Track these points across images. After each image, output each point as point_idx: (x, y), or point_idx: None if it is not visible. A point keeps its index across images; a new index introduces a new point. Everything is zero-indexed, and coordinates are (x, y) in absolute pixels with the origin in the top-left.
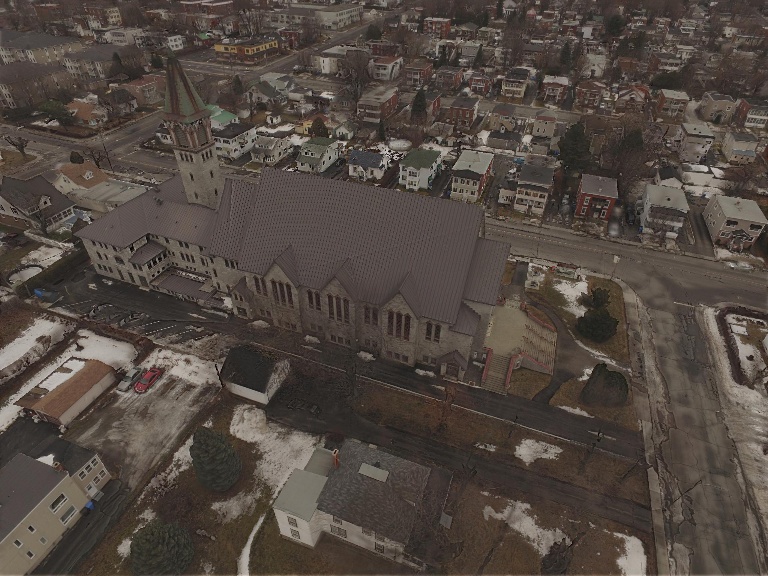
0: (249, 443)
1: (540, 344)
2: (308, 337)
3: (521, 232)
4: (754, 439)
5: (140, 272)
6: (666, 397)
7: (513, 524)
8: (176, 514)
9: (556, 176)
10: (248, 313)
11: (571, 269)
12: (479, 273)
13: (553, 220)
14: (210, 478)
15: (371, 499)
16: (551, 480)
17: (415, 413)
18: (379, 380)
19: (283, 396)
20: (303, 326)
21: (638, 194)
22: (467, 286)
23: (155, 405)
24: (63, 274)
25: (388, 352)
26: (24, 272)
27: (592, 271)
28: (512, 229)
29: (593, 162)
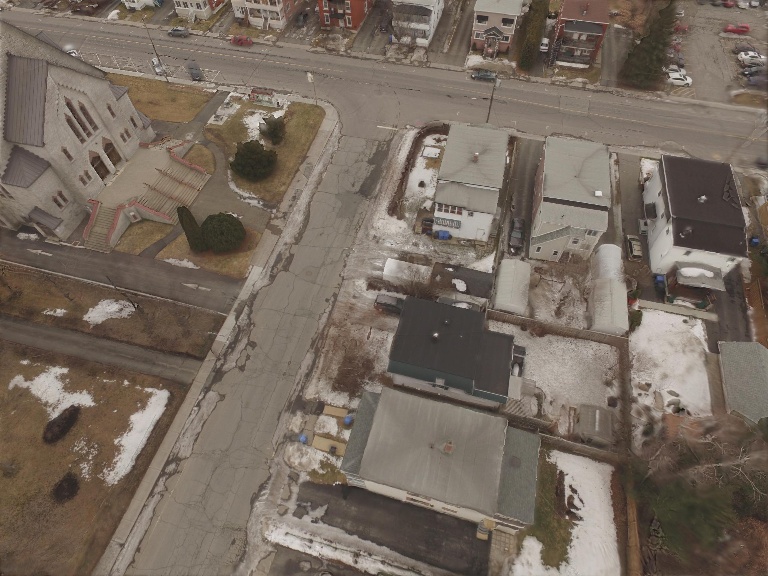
0: None
1: (175, 190)
2: None
3: (244, 54)
4: (366, 274)
5: None
6: (297, 238)
7: (37, 391)
8: None
9: None
10: None
11: None
12: (19, 105)
13: (293, 35)
14: None
15: None
16: (108, 341)
17: None
18: None
19: None
20: None
21: None
22: (9, 124)
23: None
24: None
25: None
26: None
27: (303, 96)
28: (235, 51)
29: None
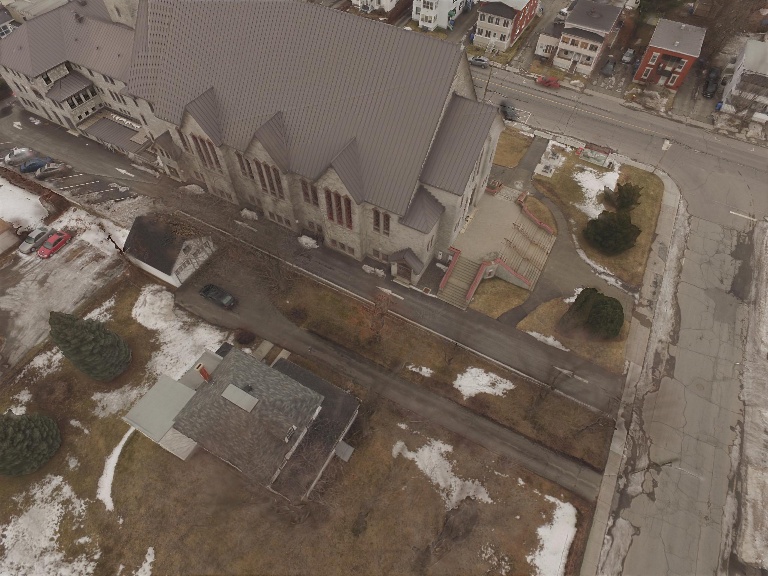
0: (149, 330)
1: (528, 250)
2: (245, 211)
3: (553, 97)
4: None
5: (62, 111)
6: (673, 336)
7: (424, 467)
8: (53, 399)
9: (626, 22)
10: (180, 174)
11: (602, 153)
12: (448, 148)
13: (601, 84)
14: (83, 368)
15: (232, 428)
16: (488, 421)
17: (347, 318)
18: (315, 273)
19: (199, 280)
20: (239, 197)
21: (733, 55)
22: (429, 165)
23: (56, 273)
24: None
25: (332, 240)
26: None
27: (631, 159)
28: (542, 92)
29: (681, 1)
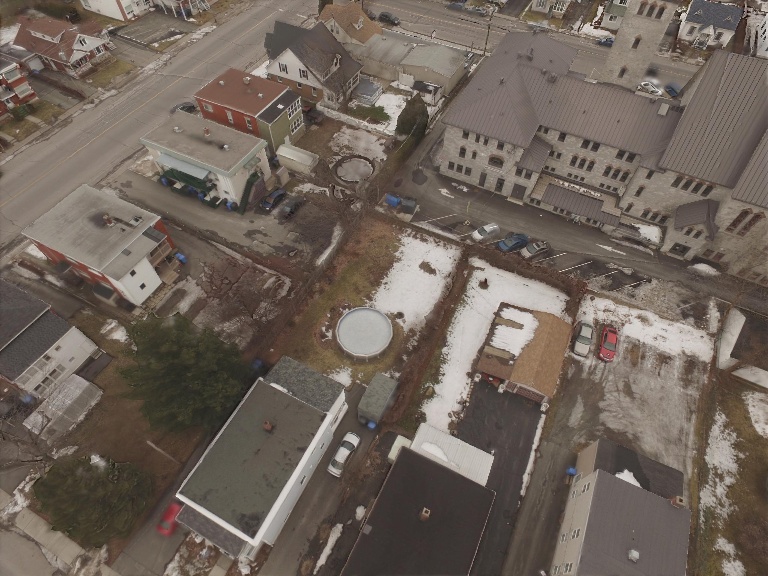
0: None
1: None
2: None
3: None
4: None
5: (523, 180)
6: None
7: None
8: (763, 550)
9: None
10: (690, 253)
11: None
12: None
13: None
14: None
15: None
16: None
17: None
18: None
19: None
20: None
21: None
22: None
23: (636, 381)
24: (397, 171)
25: None
26: (350, 165)
27: None
28: None
29: None
